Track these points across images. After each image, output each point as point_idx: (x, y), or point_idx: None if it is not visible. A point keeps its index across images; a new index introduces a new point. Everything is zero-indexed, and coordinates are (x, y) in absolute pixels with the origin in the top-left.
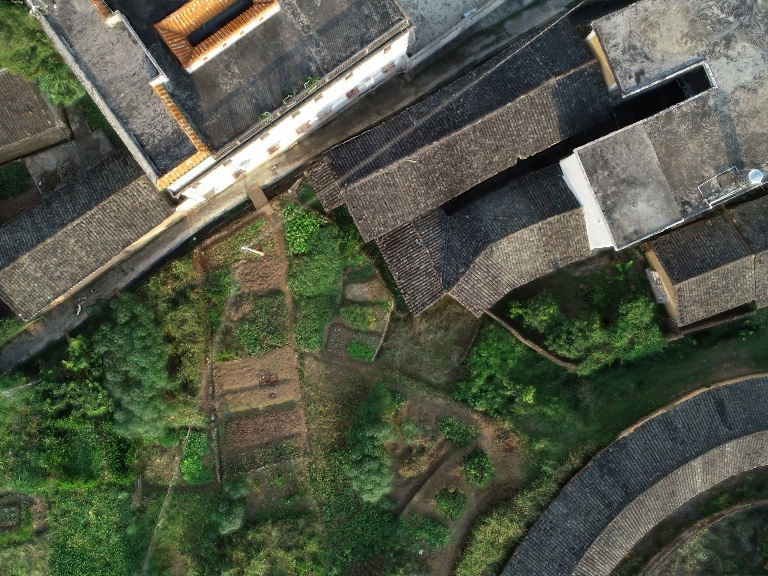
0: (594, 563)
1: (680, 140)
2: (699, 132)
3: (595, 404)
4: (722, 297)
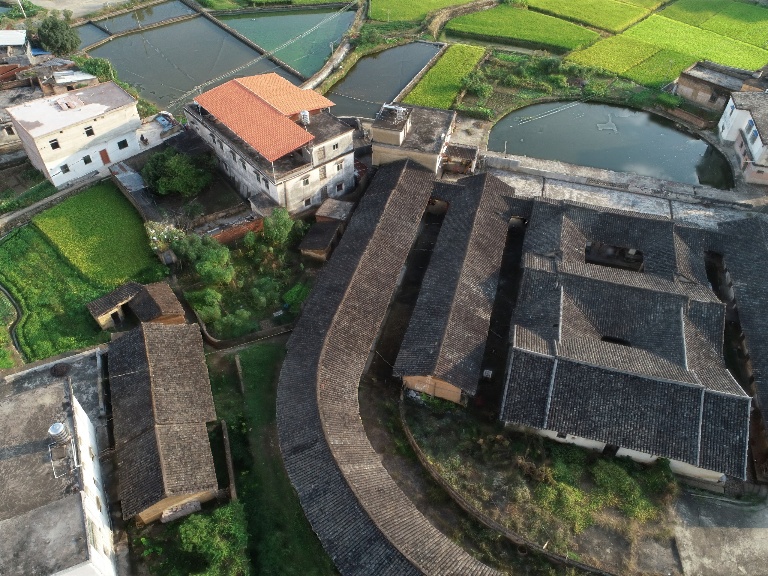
0: (455, 574)
1: (1, 497)
2: (1, 479)
3: (292, 575)
4: (194, 451)
